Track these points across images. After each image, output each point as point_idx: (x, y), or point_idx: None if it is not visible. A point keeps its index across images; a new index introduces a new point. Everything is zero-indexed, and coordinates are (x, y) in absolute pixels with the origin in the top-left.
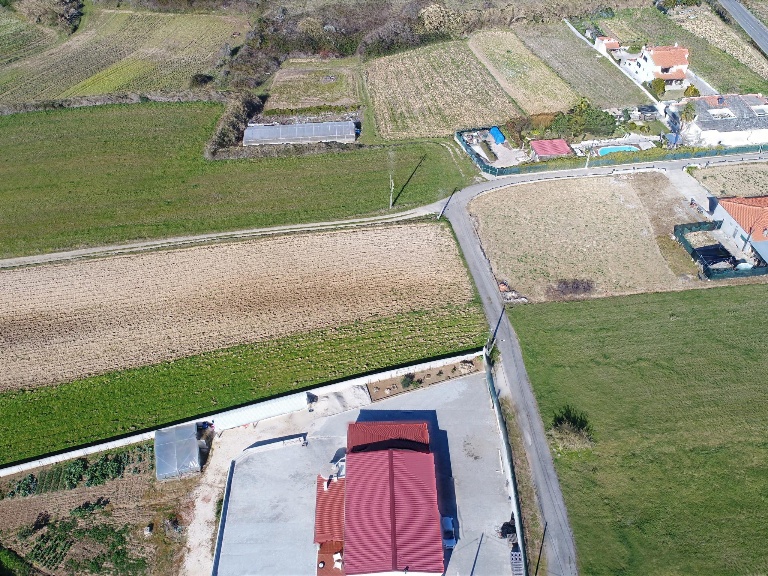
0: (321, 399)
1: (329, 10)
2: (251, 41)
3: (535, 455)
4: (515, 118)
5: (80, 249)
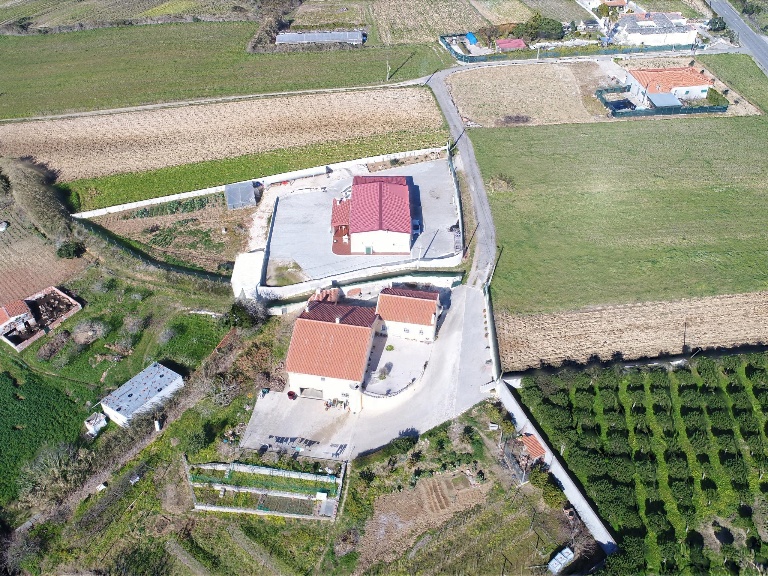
0: (335, 171)
1: None
2: None
3: (476, 195)
4: (486, 27)
5: (159, 104)
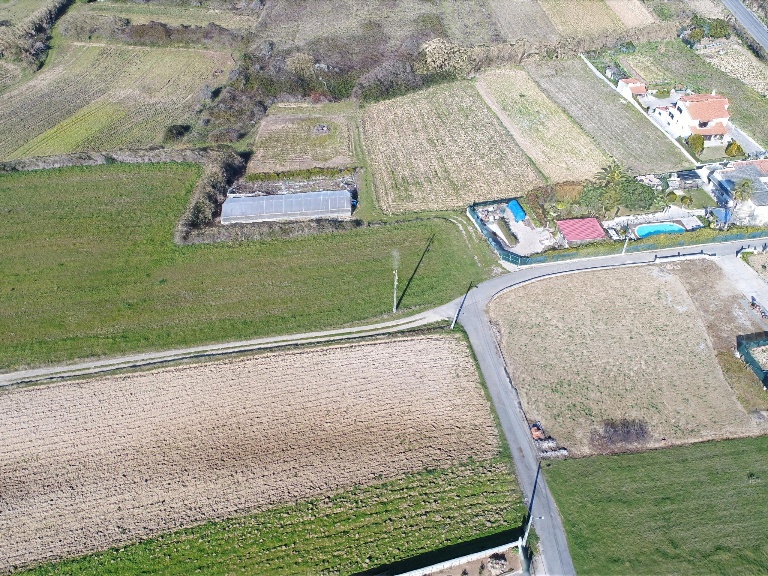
0: None
1: (321, 44)
2: (234, 82)
3: None
4: (537, 189)
5: (19, 371)
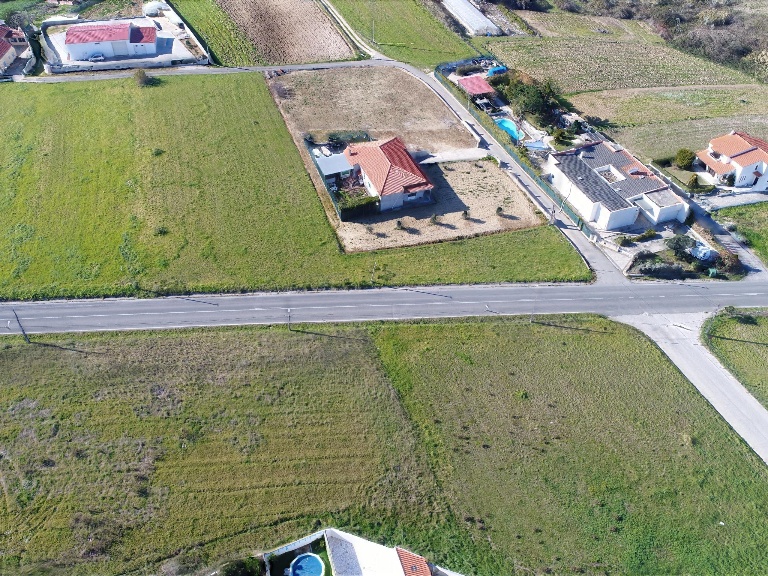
0: None
1: (757, 18)
2: None
3: None
4: (523, 72)
5: None
